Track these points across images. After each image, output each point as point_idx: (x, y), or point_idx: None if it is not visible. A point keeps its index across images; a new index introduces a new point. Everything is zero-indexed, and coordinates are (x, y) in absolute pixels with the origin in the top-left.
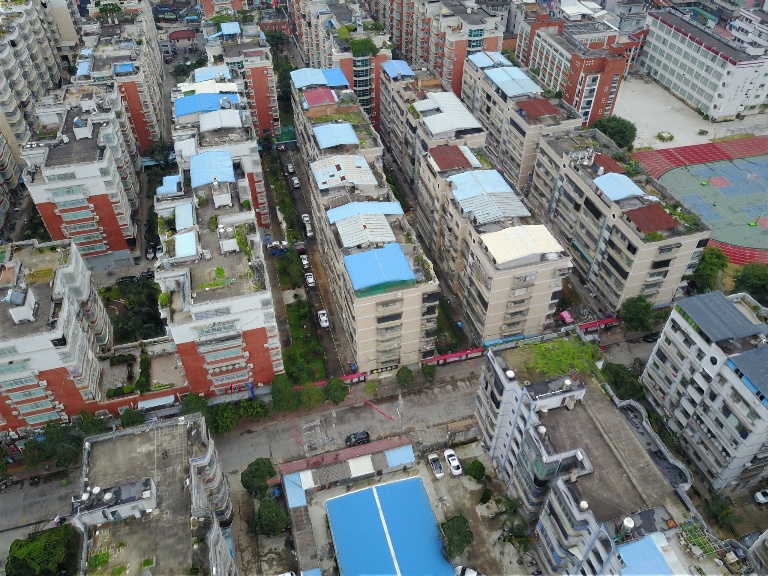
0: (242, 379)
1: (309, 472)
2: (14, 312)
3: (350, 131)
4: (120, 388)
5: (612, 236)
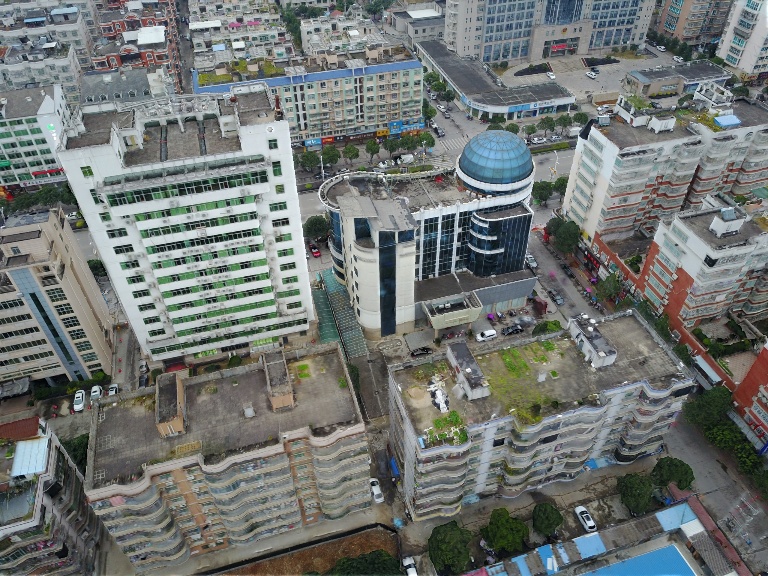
0: None
1: (702, 529)
2: (716, 220)
3: None
4: (705, 336)
5: None
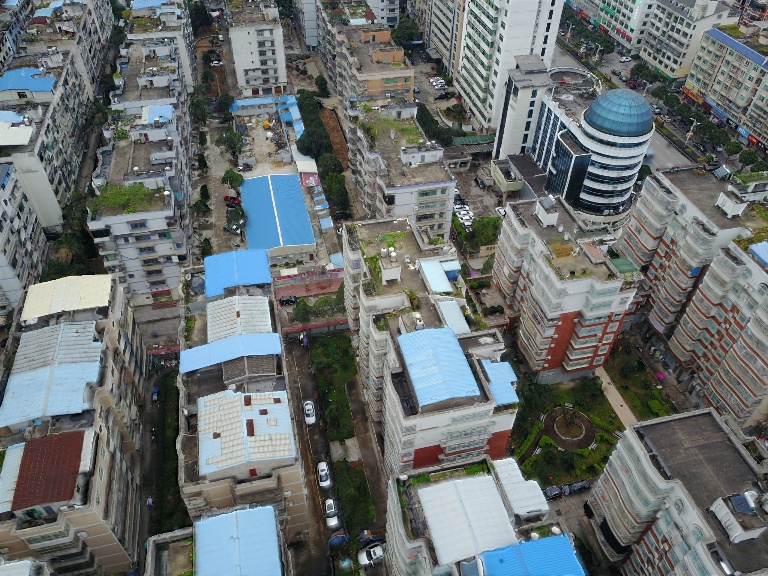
0: None
1: None
2: None
3: (203, 573)
4: (480, 282)
5: None
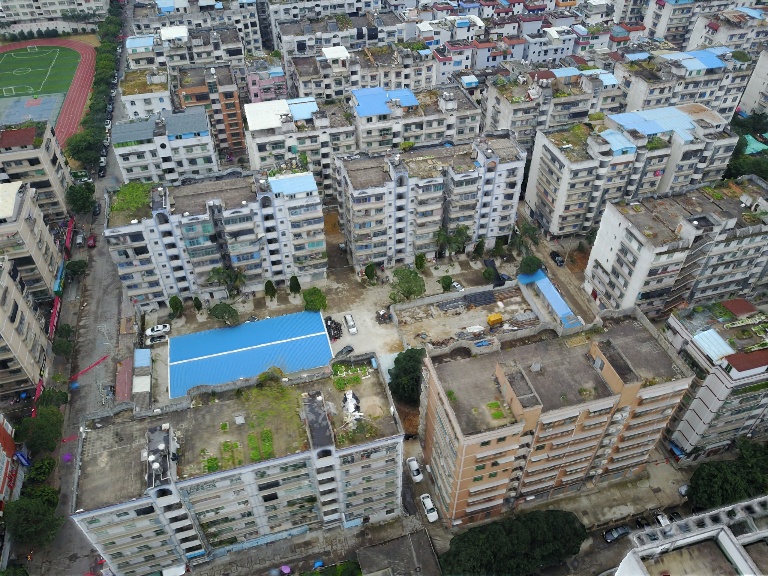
0: (6, 463)
1: None
2: None
3: None
4: None
5: (8, 172)
